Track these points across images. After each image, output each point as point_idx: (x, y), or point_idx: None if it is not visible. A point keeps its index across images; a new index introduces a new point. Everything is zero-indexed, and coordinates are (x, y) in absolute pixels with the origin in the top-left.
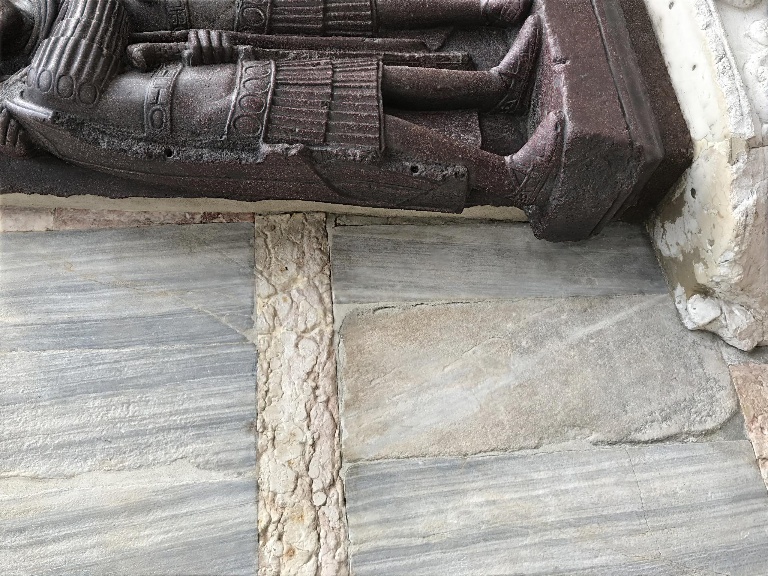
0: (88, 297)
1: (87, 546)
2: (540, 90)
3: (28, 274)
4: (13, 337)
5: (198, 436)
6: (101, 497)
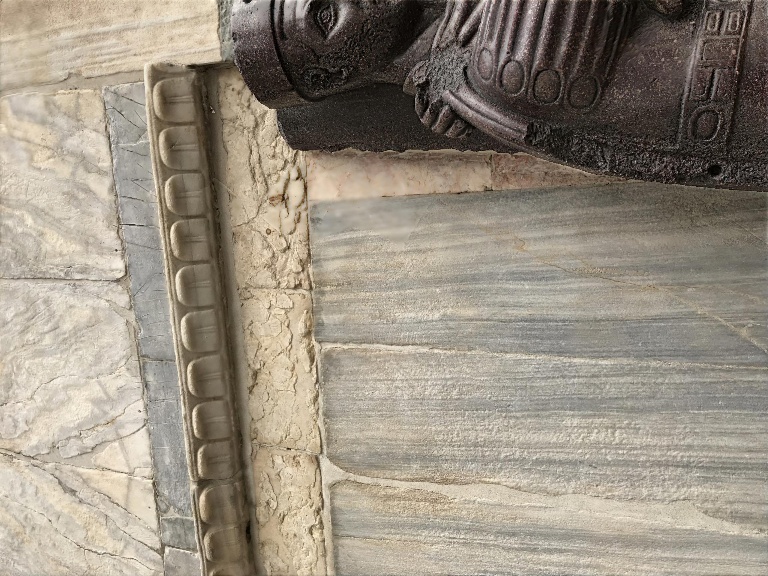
0: (550, 288)
1: (580, 565)
2: None
3: (473, 253)
4: (469, 333)
5: (705, 479)
6: (590, 522)
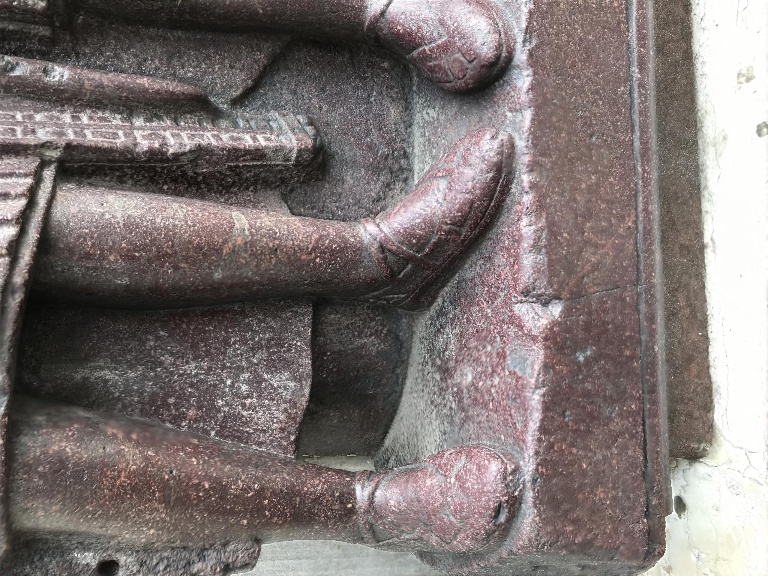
0: None
1: None
2: (466, 306)
3: None
4: None
5: None
6: None
